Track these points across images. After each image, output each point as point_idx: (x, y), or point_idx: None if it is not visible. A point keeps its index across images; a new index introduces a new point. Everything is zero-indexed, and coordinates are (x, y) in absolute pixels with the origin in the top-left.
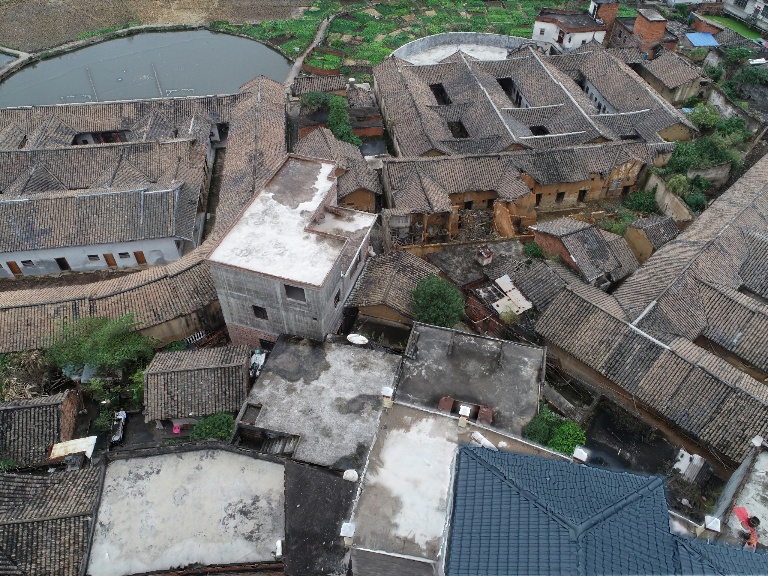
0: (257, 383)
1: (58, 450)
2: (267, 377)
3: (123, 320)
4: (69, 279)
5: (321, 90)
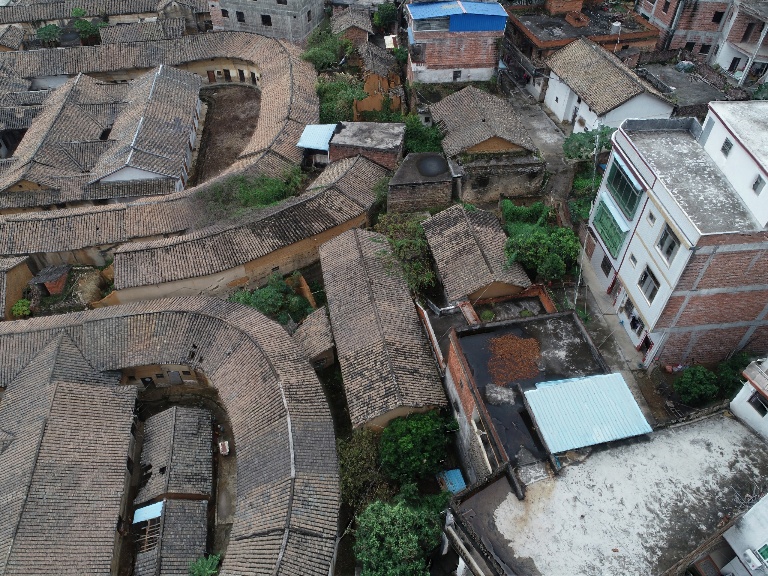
0: (360, 5)
1: (390, 46)
2: (357, 3)
3: (318, 30)
4: (216, 132)
5: (20, 39)
